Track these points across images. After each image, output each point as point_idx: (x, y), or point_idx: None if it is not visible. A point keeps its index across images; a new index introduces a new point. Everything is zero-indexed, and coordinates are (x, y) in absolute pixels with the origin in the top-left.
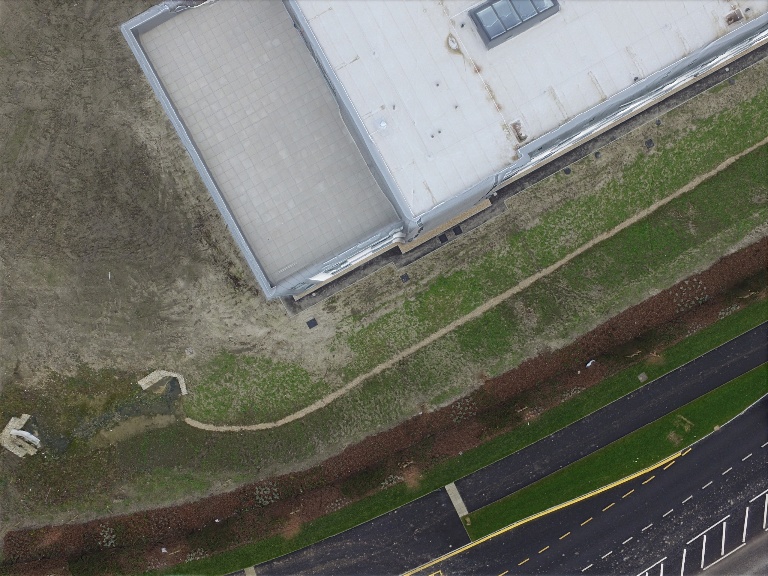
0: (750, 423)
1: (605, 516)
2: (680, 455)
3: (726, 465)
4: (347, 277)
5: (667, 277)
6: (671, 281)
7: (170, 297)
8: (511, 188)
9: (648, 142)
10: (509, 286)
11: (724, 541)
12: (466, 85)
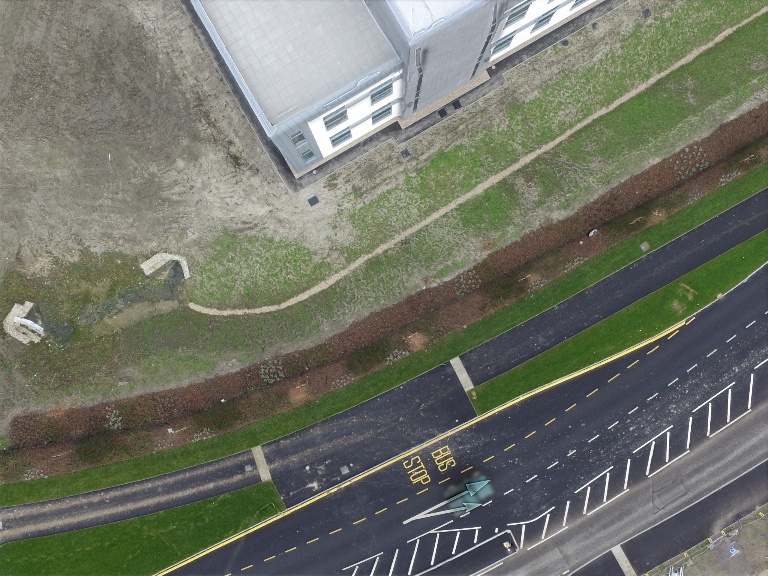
0: (753, 290)
1: (610, 387)
2: (684, 324)
3: (730, 333)
4: (347, 154)
5: (667, 146)
6: (671, 149)
7: (170, 178)
8: (509, 61)
9: (645, 12)
10: (509, 163)
11: (730, 408)
12: None
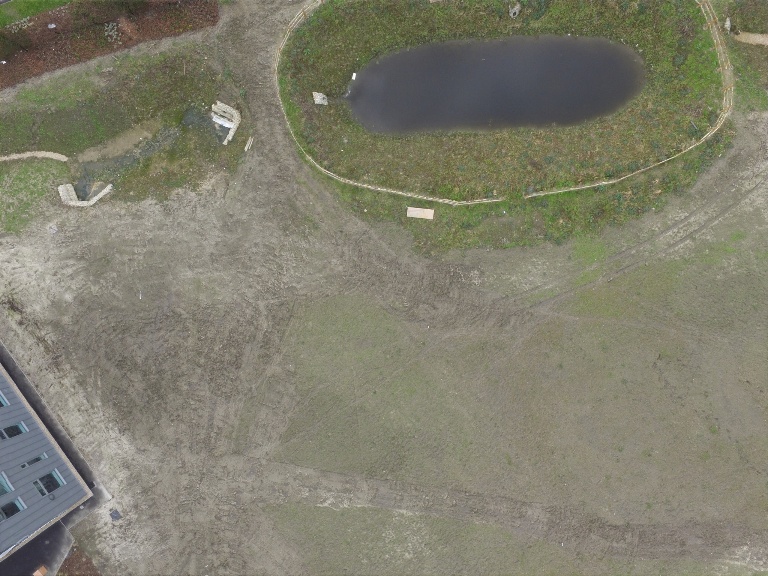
0: None
1: None
2: None
3: None
4: None
5: None
6: None
7: (78, 282)
8: None
9: None
10: None
11: None
12: None
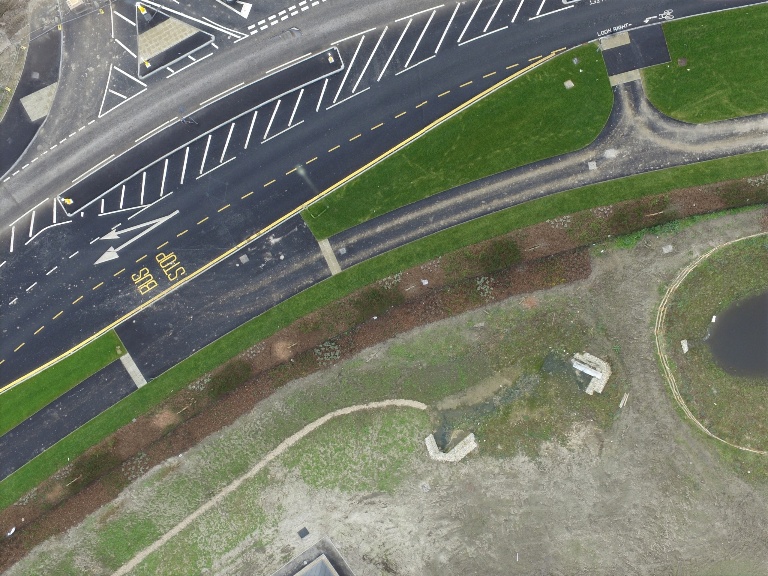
0: None
1: None
2: None
3: None
4: None
5: None
6: None
7: (452, 542)
8: None
9: None
10: None
11: None
12: None
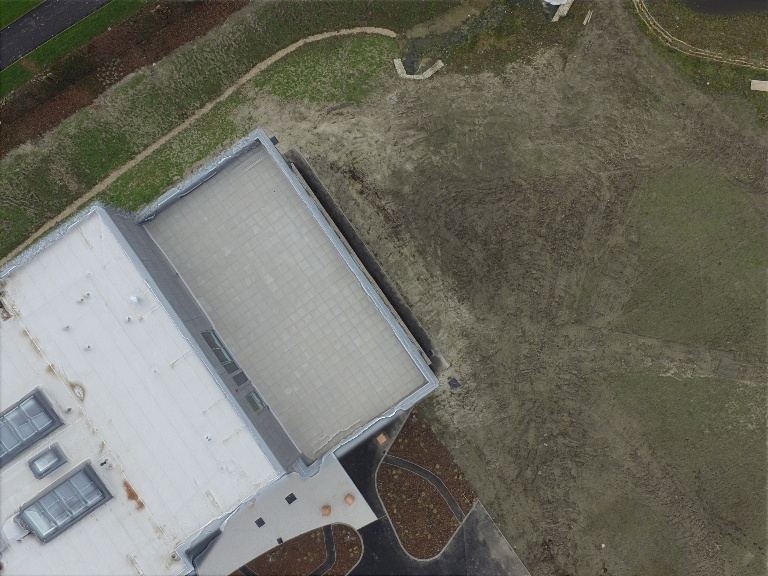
0: None
1: None
2: None
3: None
4: None
5: None
6: None
7: (418, 152)
8: None
9: None
10: (86, 205)
11: None
12: (60, 350)
